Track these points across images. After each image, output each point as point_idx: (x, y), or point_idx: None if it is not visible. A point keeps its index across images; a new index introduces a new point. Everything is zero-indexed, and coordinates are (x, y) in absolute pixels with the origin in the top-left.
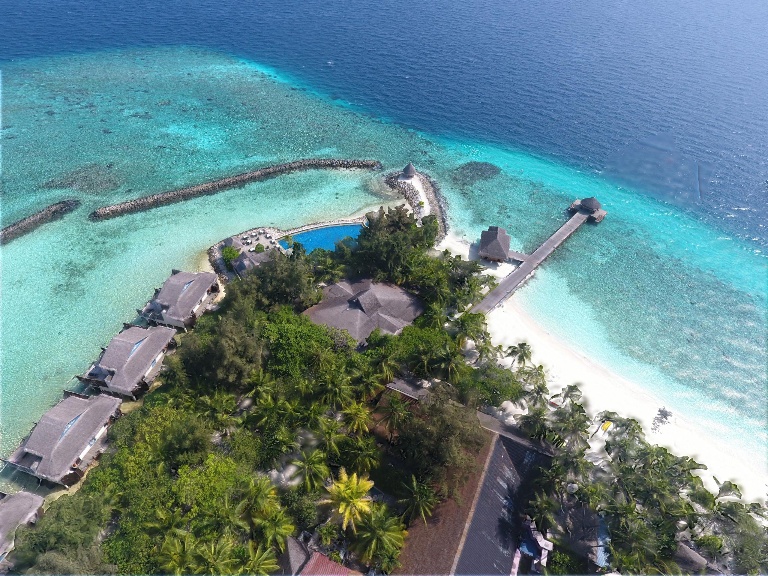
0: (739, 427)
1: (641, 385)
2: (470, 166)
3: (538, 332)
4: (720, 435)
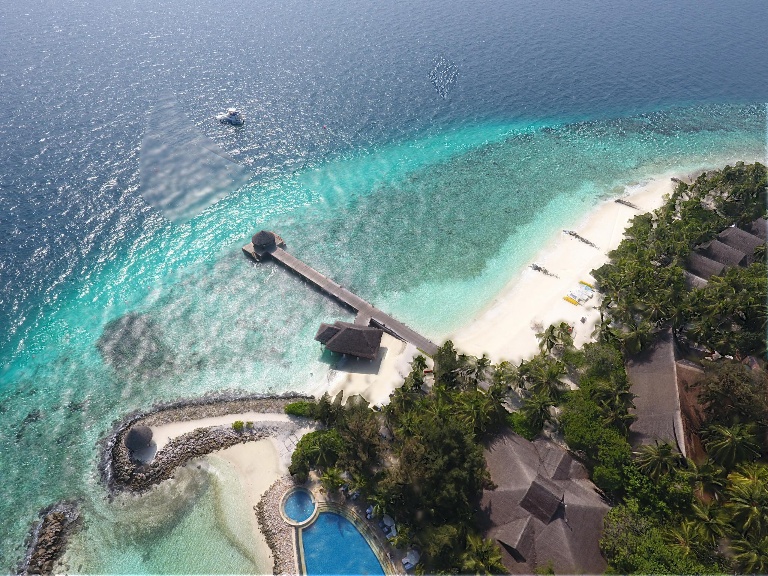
0: (525, 236)
1: (512, 273)
2: (113, 349)
3: (477, 327)
4: (540, 246)
